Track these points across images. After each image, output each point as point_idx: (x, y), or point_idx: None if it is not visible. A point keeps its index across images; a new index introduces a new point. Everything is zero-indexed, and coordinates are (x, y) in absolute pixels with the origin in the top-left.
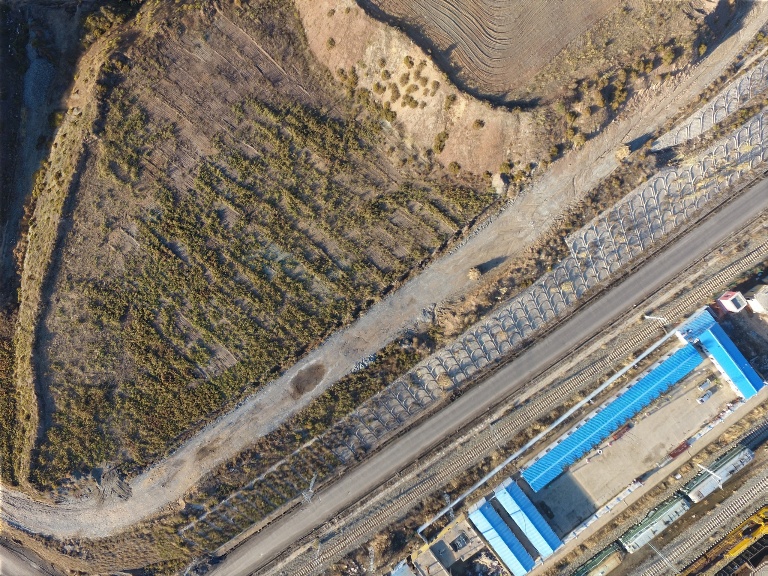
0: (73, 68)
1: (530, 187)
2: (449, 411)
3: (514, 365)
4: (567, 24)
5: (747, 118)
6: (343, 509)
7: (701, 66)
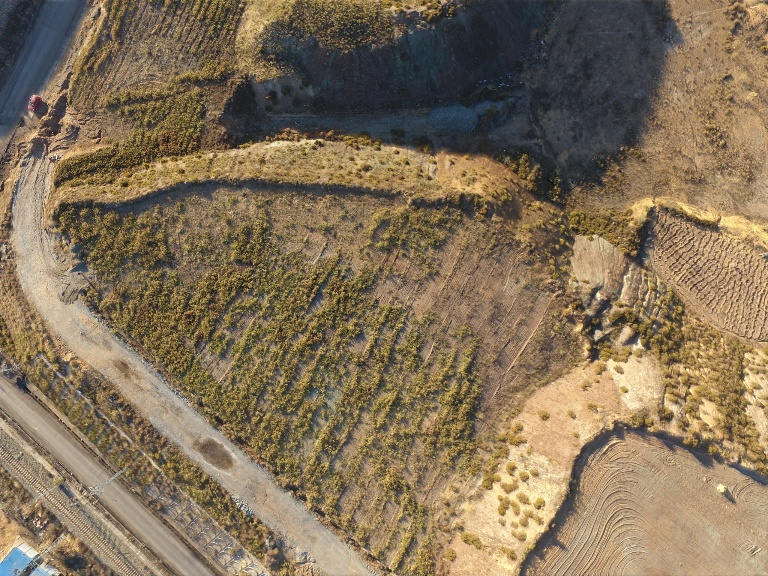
0: (476, 150)
1: None
2: None
3: None
4: None
5: None
6: None
7: None
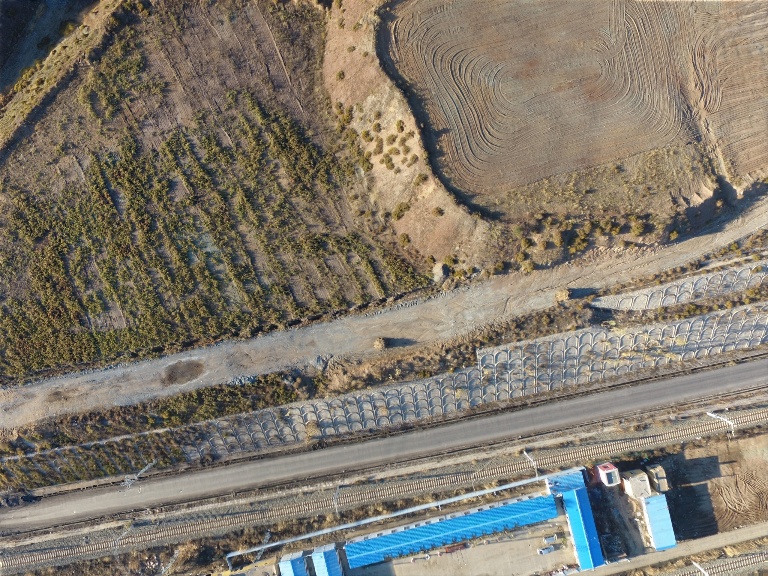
0: None
1: (466, 288)
2: (307, 457)
3: (385, 442)
4: (559, 157)
5: (693, 314)
6: (169, 504)
7: (668, 249)
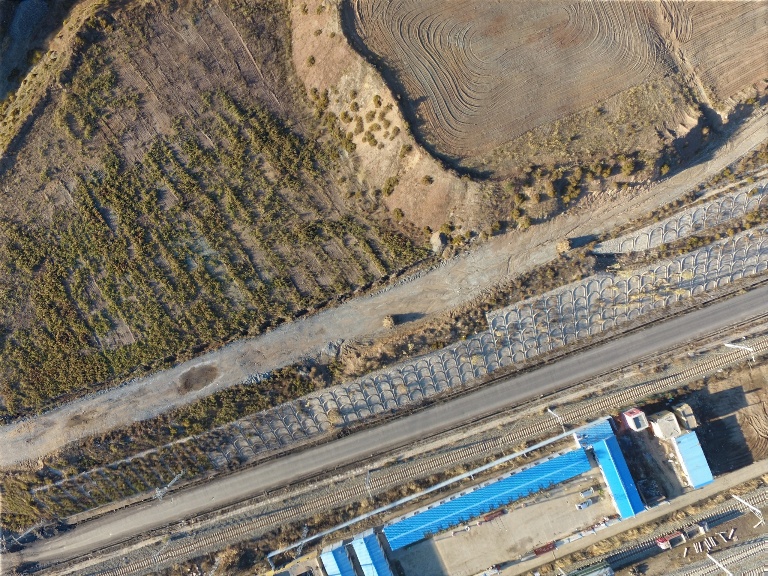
0: (66, 12)
1: (466, 254)
2: (333, 447)
3: (408, 420)
4: (539, 108)
5: (695, 247)
6: (203, 513)
7: (662, 185)
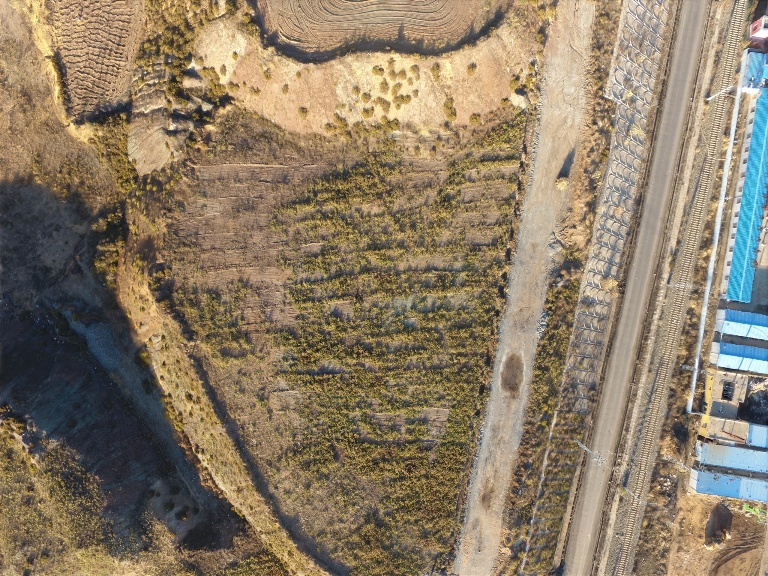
0: (119, 310)
1: (544, 81)
2: (628, 303)
3: (644, 225)
4: None
5: None
6: (617, 447)
7: None
